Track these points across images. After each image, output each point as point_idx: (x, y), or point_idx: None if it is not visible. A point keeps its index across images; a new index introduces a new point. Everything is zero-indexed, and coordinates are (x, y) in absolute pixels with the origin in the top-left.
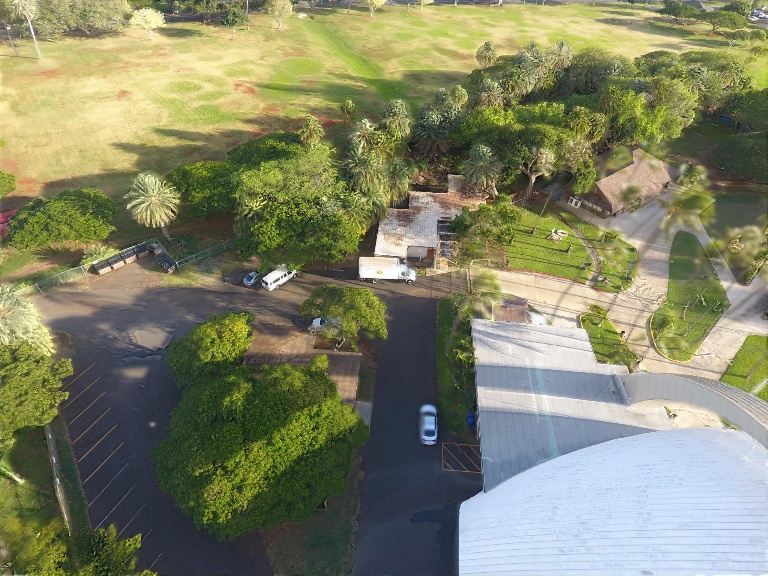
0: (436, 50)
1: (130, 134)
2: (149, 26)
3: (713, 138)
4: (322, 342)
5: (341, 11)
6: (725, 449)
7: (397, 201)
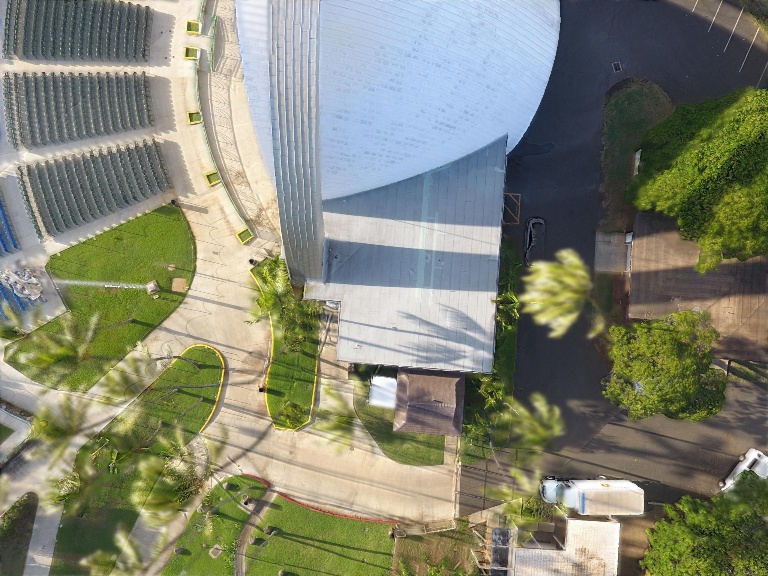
0: None
1: None
2: None
3: None
4: None
5: None
6: None
7: None
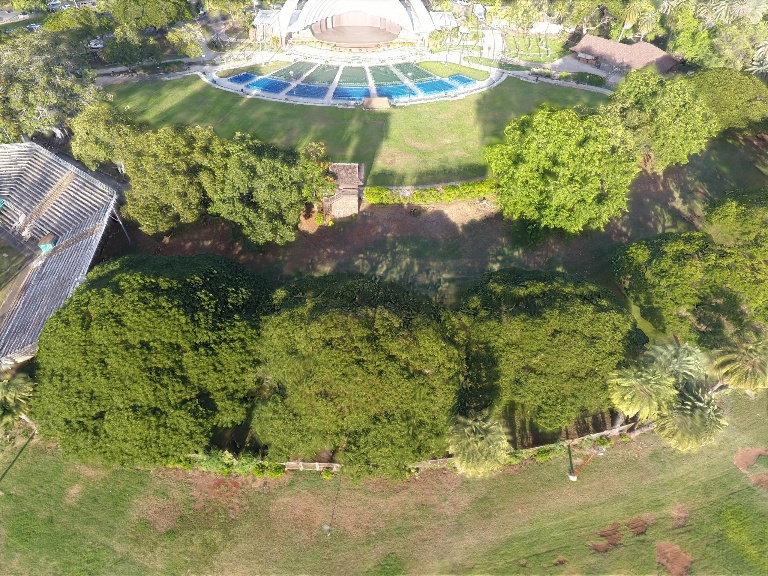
0: None
1: None
2: None
3: None
4: None
5: None
6: None
7: None
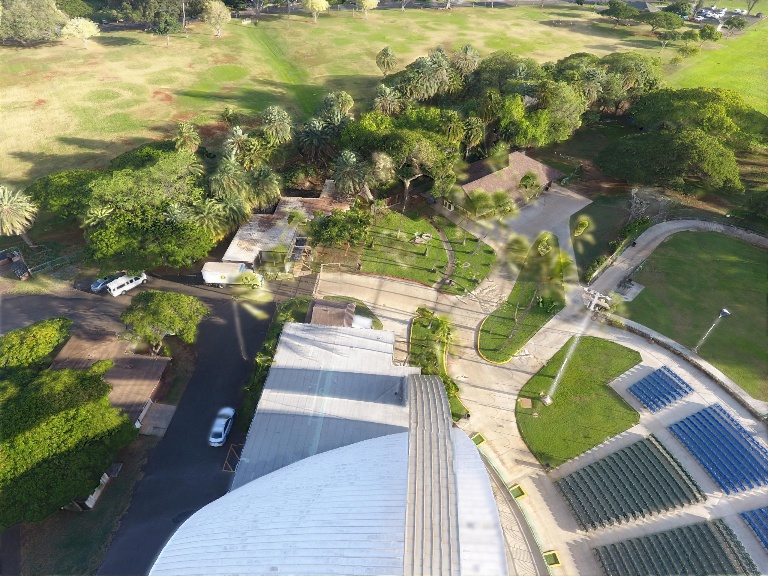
0: (368, 55)
1: (33, 143)
2: (82, 35)
3: (614, 139)
4: (148, 346)
5: (286, 17)
6: None
7: (266, 206)
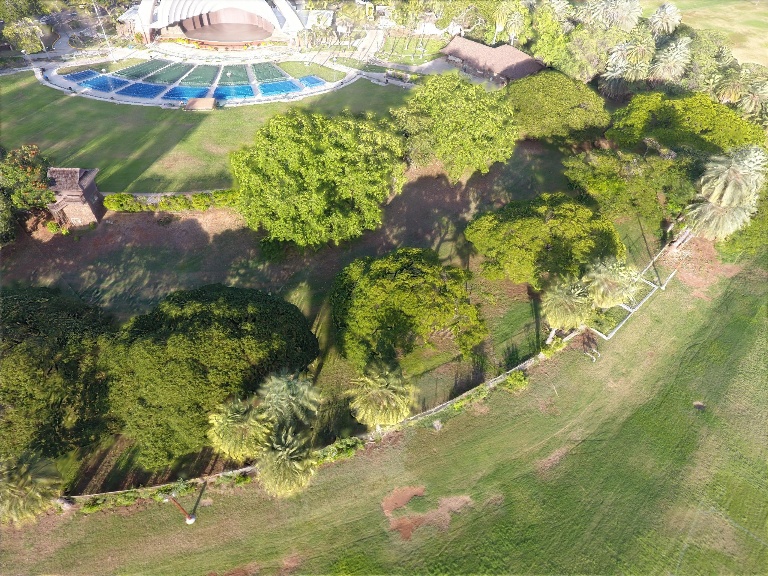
0: (733, 34)
1: None
2: None
3: None
4: None
5: None
6: None
7: None
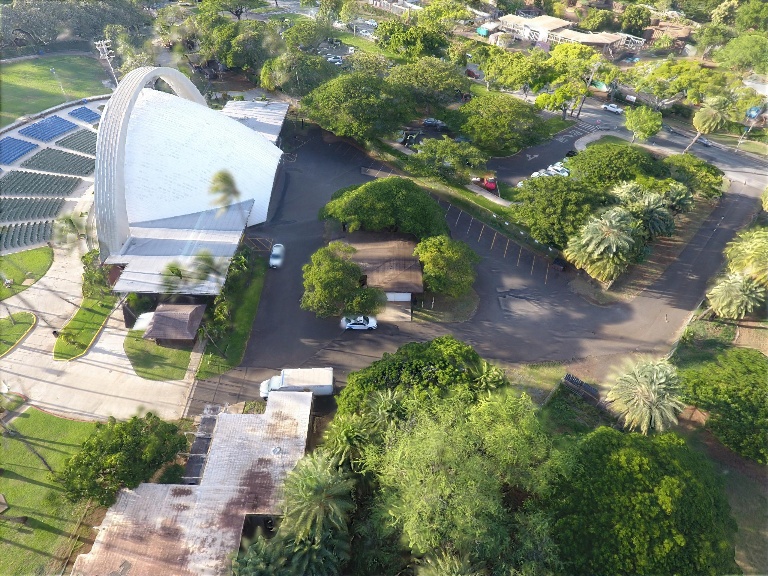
0: None
1: None
2: None
3: None
4: None
5: None
6: (128, 153)
7: None
